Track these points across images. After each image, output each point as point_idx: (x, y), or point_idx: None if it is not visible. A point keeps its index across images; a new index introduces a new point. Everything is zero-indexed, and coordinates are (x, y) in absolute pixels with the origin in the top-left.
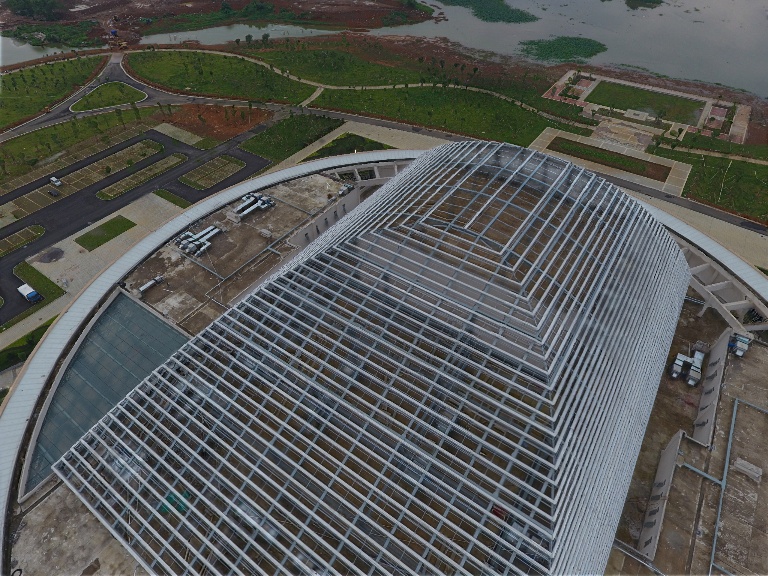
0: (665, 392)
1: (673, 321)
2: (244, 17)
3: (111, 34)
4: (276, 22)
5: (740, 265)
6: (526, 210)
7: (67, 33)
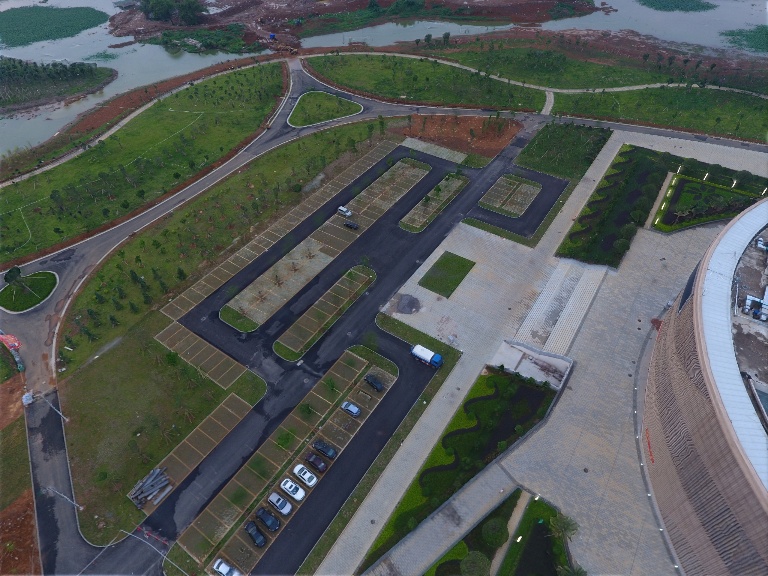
0: None
1: None
2: (395, 14)
3: (267, 38)
4: (432, 19)
5: None
6: None
7: (222, 38)
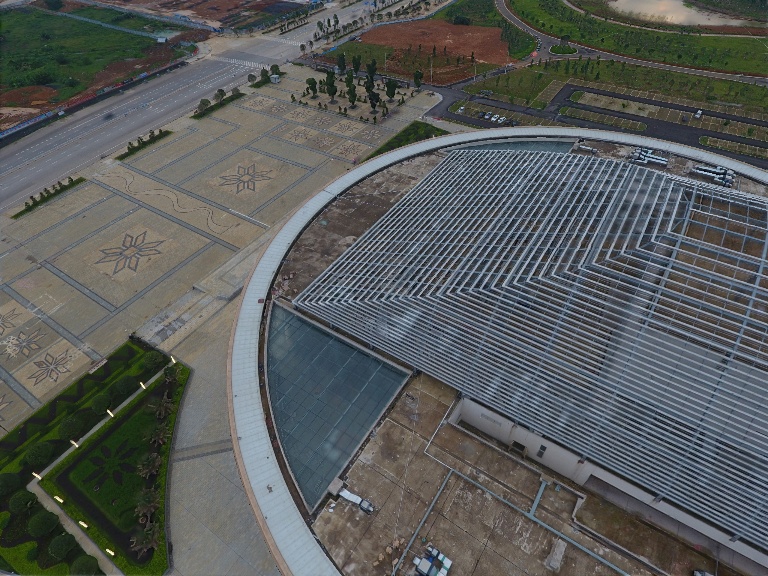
0: (663, 553)
1: (764, 530)
2: None
3: None
4: None
5: None
6: (765, 256)
7: None
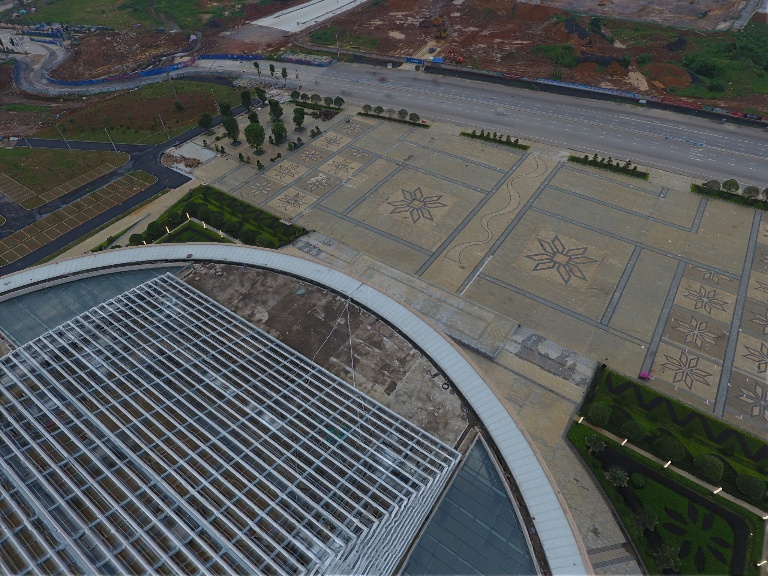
0: None
1: None
2: None
3: None
4: None
5: None
6: None
7: None
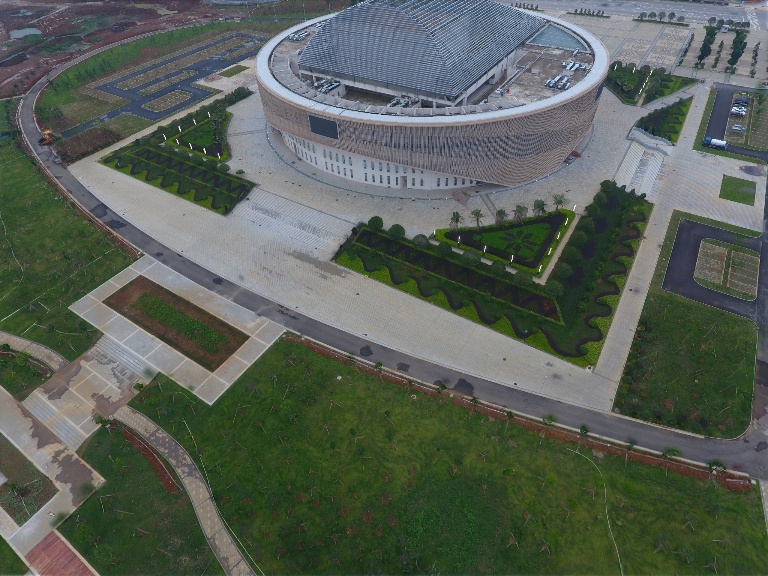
0: None
1: None
2: None
3: None
4: None
5: (263, 73)
6: None
7: None
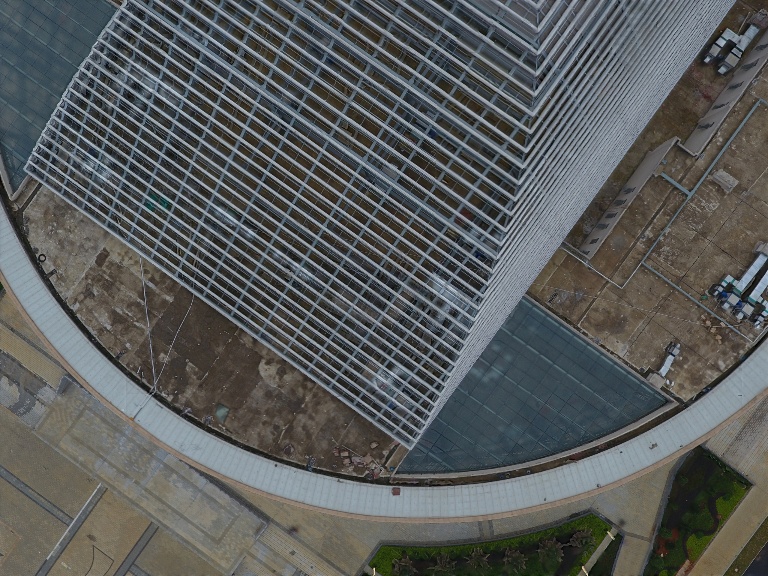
0: (685, 82)
1: None
2: None
3: None
4: None
5: None
6: None
7: None
